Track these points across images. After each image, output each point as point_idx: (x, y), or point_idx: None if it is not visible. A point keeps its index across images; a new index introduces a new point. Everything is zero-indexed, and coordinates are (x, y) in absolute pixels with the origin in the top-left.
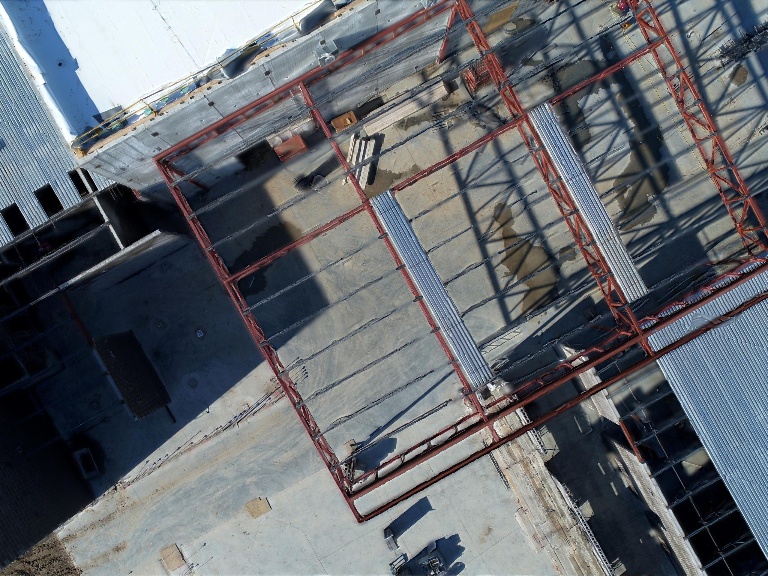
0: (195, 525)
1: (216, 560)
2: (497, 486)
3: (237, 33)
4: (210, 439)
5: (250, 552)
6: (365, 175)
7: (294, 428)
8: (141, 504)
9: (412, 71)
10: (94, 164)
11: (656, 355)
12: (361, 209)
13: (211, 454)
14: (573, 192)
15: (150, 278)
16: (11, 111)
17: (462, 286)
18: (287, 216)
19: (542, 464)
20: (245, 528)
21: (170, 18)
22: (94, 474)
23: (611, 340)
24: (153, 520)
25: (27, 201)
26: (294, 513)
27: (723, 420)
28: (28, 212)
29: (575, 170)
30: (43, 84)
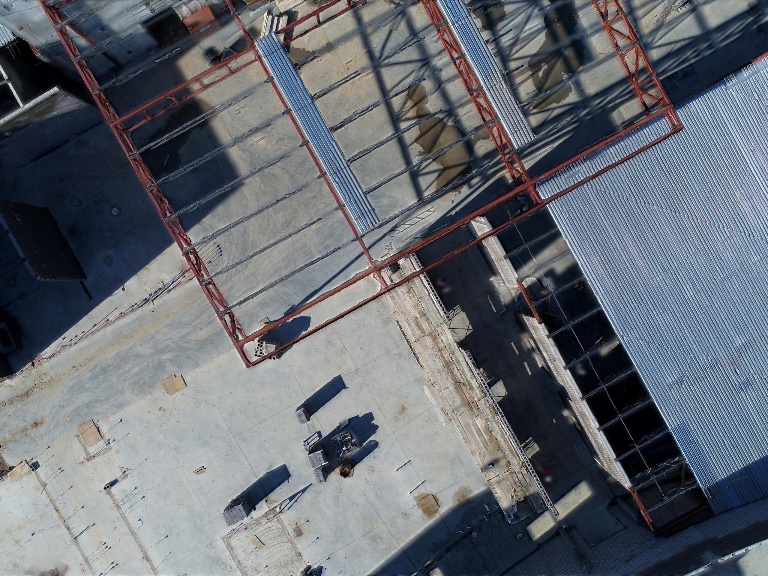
0: (111, 401)
1: (132, 436)
2: (410, 365)
3: None
4: (126, 316)
5: (166, 428)
6: None
7: (209, 306)
8: (58, 380)
9: None
10: None
11: (543, 202)
12: (253, 60)
13: (127, 331)
14: (459, 35)
15: (65, 156)
16: None
17: (376, 165)
18: (201, 94)
19: (450, 337)
20: (161, 405)
21: None
22: (11, 349)
23: (508, 198)
24: (70, 396)
25: None
26: (209, 390)
27: (621, 280)
28: None
29: (461, 13)
30: None
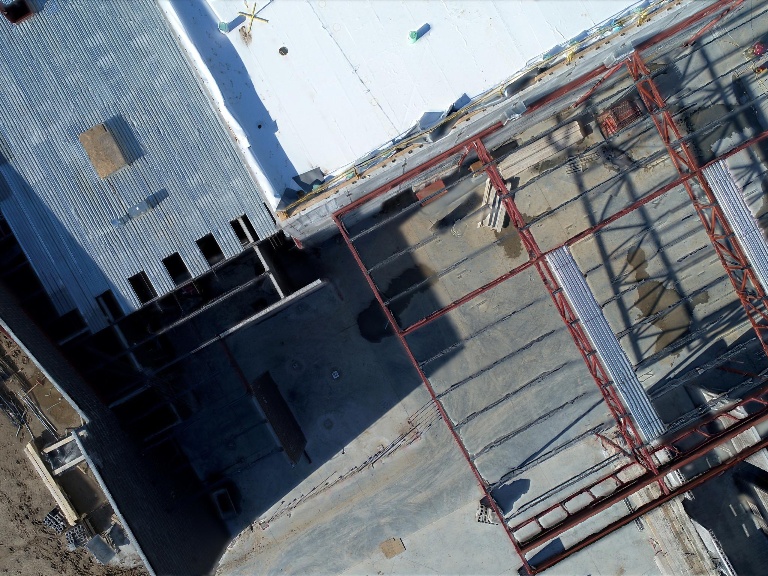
0: (330, 565)
1: None
2: (629, 527)
3: (436, 96)
4: (345, 480)
5: None
6: (501, 218)
7: (428, 469)
8: (276, 544)
9: (549, 116)
10: (292, 225)
11: None
12: (528, 261)
13: (346, 495)
14: (746, 248)
15: (286, 320)
16: (174, 161)
17: None
18: (422, 258)
19: (682, 508)
20: (379, 568)
21: (369, 81)
22: (231, 515)
23: (767, 390)
24: (288, 560)
25: (189, 250)
26: (428, 554)
27: None
28: (190, 261)
29: (749, 226)
30: (248, 148)
